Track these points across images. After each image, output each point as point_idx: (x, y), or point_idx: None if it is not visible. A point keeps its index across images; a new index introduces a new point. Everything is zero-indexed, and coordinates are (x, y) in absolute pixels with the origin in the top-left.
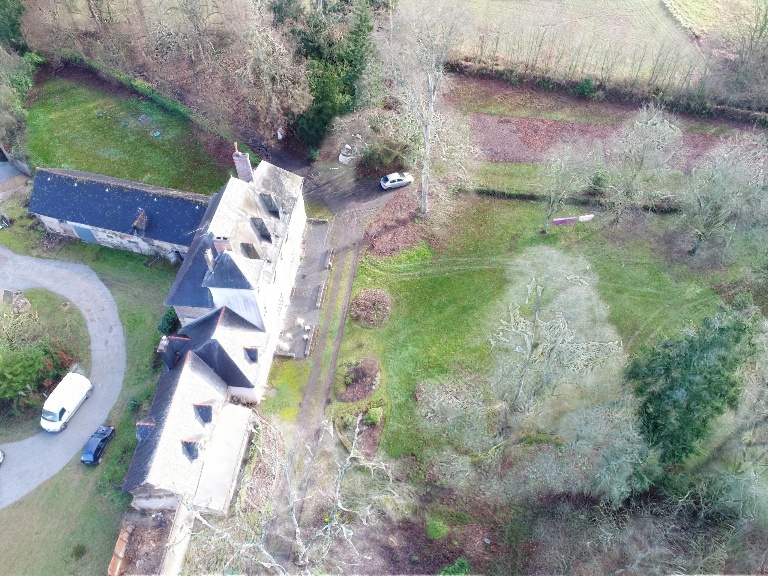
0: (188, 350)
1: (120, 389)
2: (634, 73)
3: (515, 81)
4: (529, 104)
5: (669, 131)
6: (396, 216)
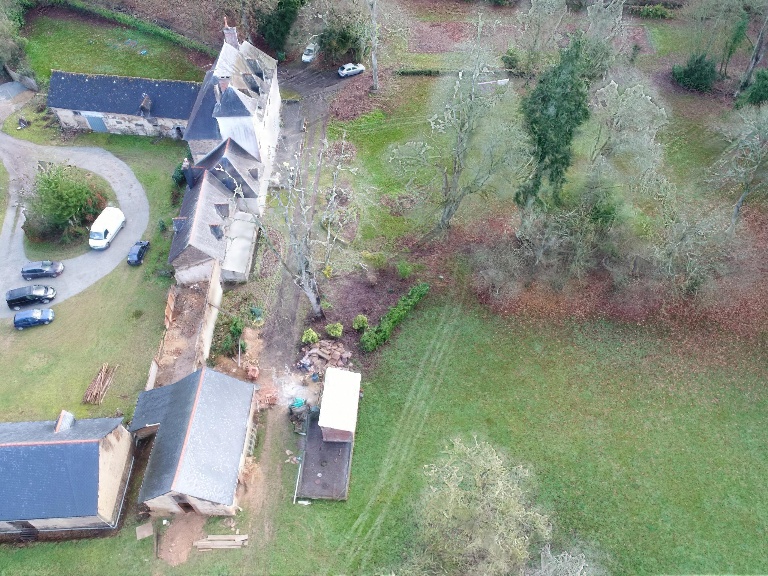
0: None
1: (148, 220)
2: None
3: None
4: (454, 12)
5: None
6: (354, 94)
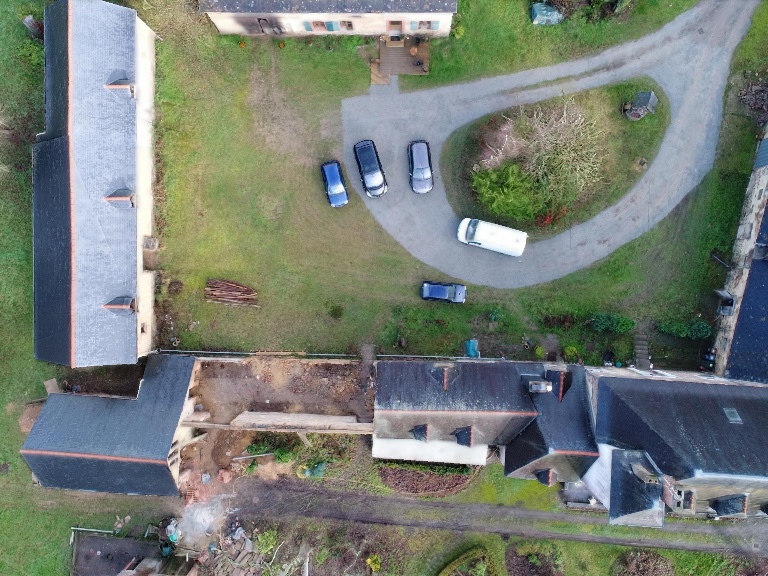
0: (543, 403)
1: (516, 287)
2: None
3: None
4: None
5: None
6: None
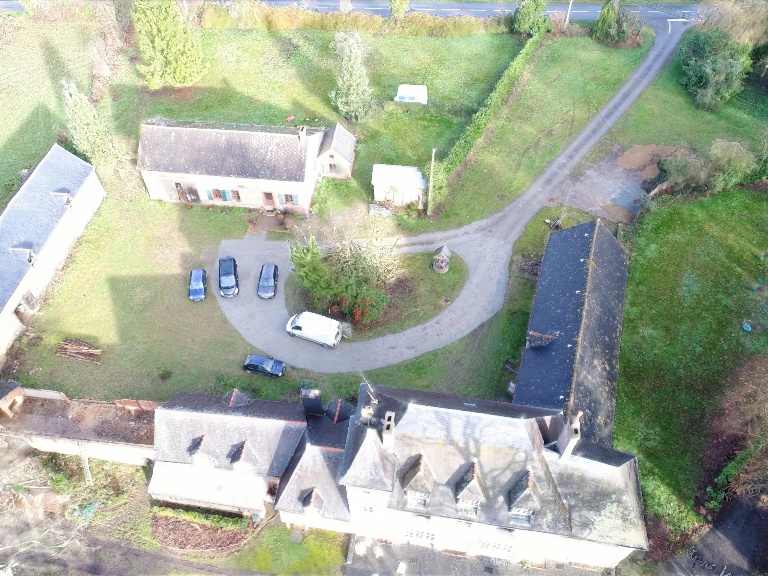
0: (318, 423)
1: (330, 372)
2: None
3: None
4: None
5: None
6: None
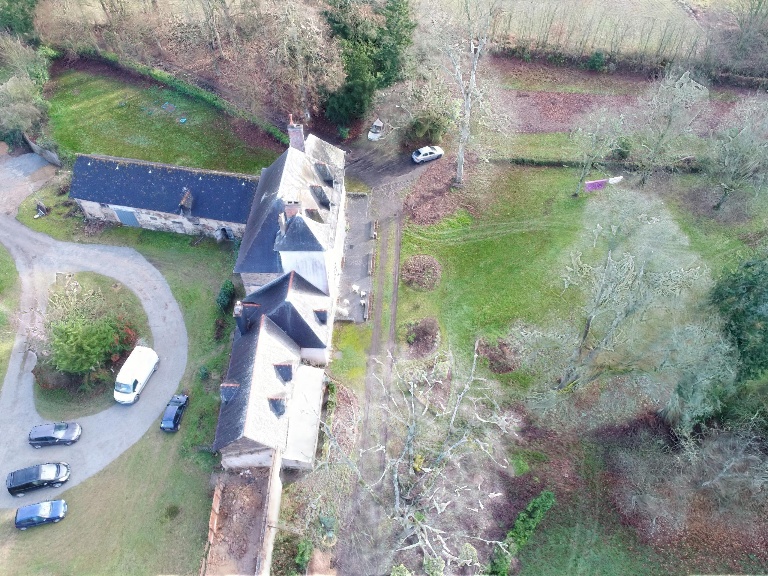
0: (259, 315)
1: (186, 361)
2: (643, 45)
3: (527, 58)
4: (544, 79)
5: (695, 91)
6: (432, 187)
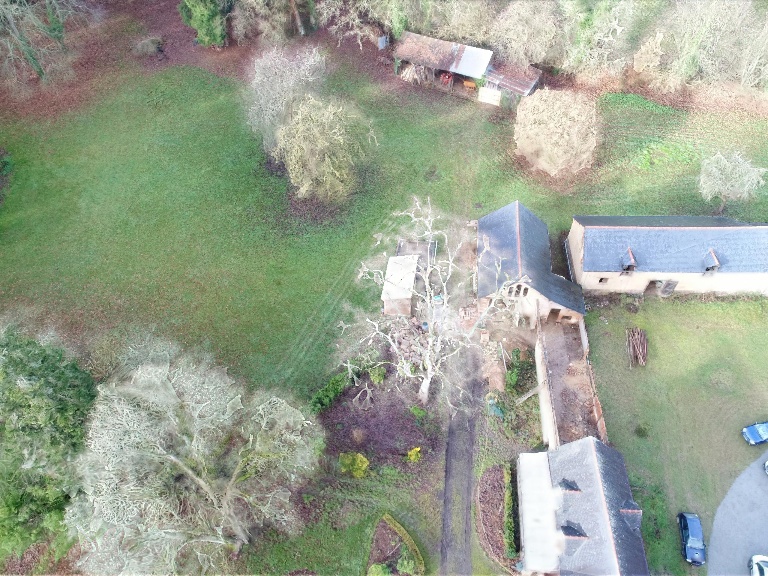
0: None
1: None
2: None
3: None
4: None
5: None
6: None
